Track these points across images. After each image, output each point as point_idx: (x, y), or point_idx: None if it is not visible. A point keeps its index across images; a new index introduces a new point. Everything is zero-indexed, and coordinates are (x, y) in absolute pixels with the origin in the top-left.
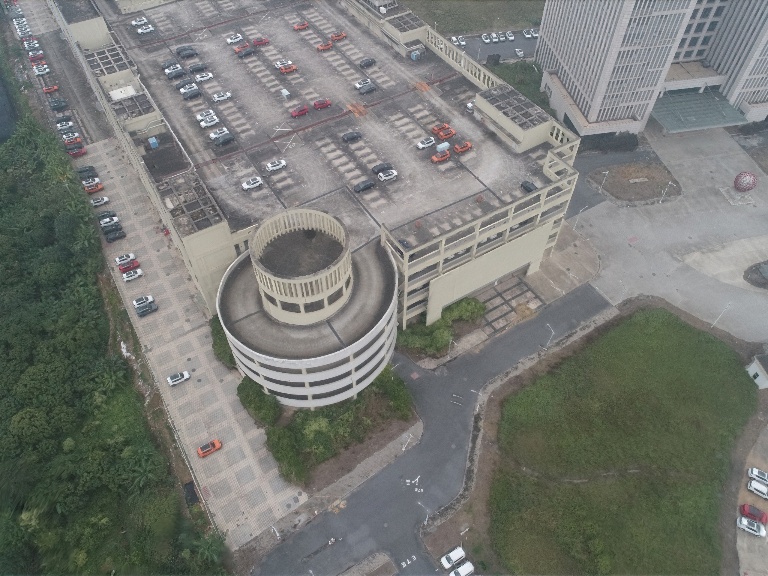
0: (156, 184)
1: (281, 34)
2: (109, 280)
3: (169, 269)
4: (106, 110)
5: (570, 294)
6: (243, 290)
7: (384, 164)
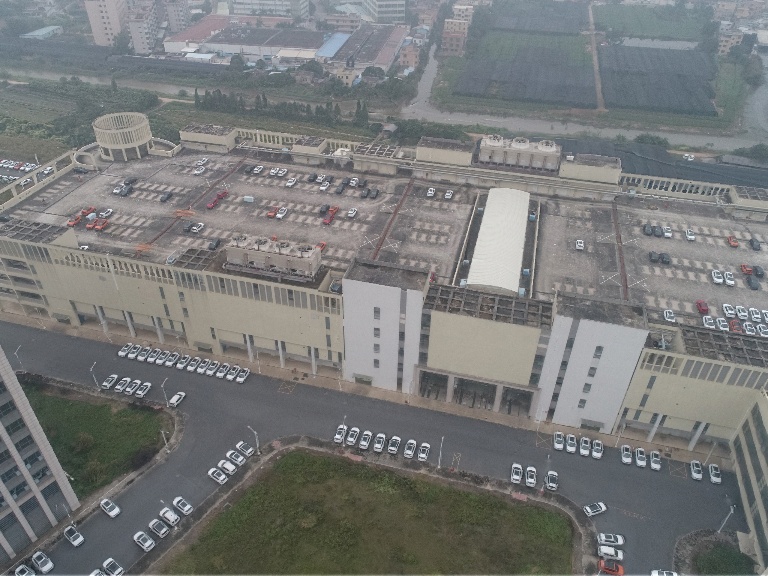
0: None
1: (329, 236)
2: None
3: None
4: None
5: None
6: None
7: (126, 190)
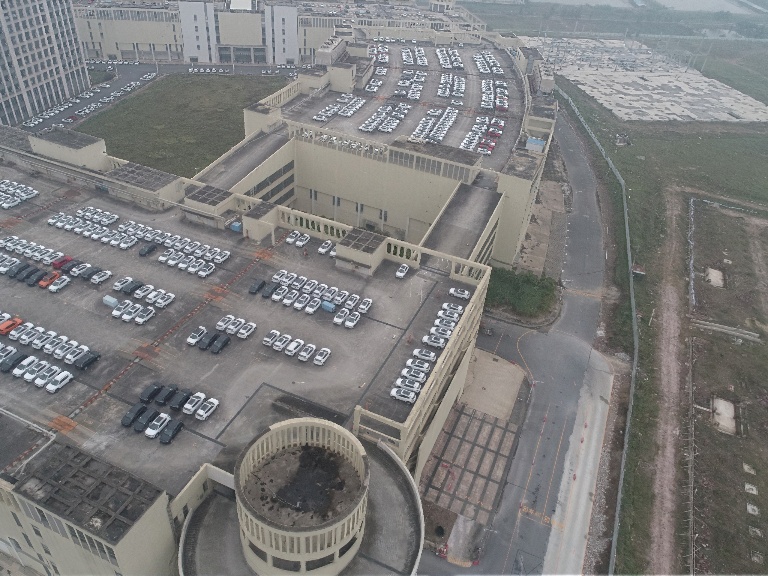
0: None
1: None
2: None
3: None
4: None
5: None
6: None
7: None
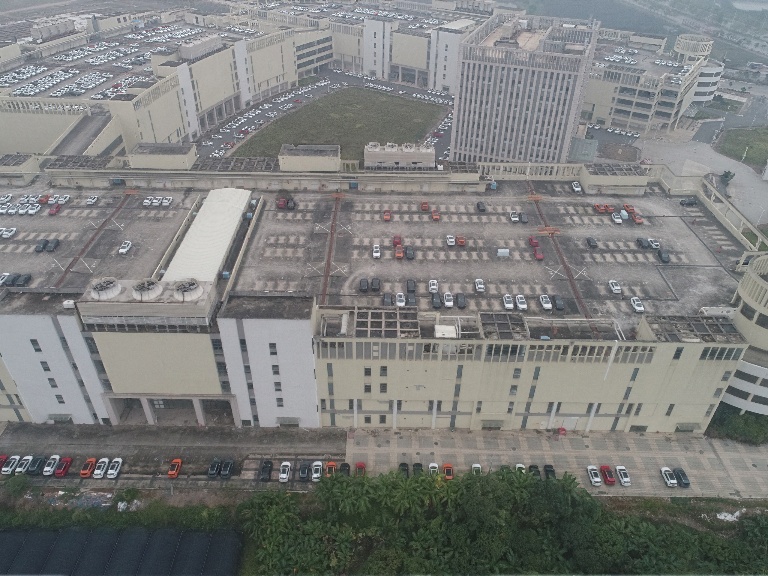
0: (658, 340)
1: (387, 229)
2: (617, 502)
3: (620, 446)
4: (359, 396)
5: None
6: (758, 360)
7: (642, 239)
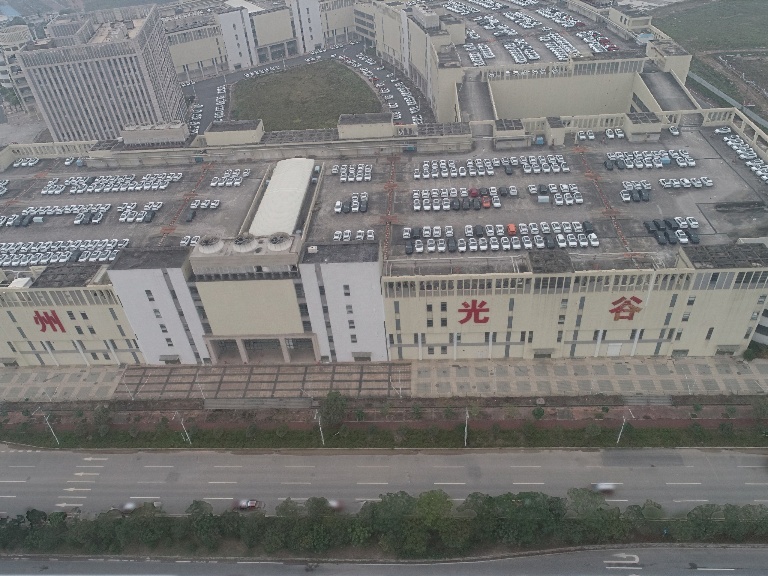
0: None
1: None
2: None
3: None
4: None
5: (6, 119)
6: None
7: None
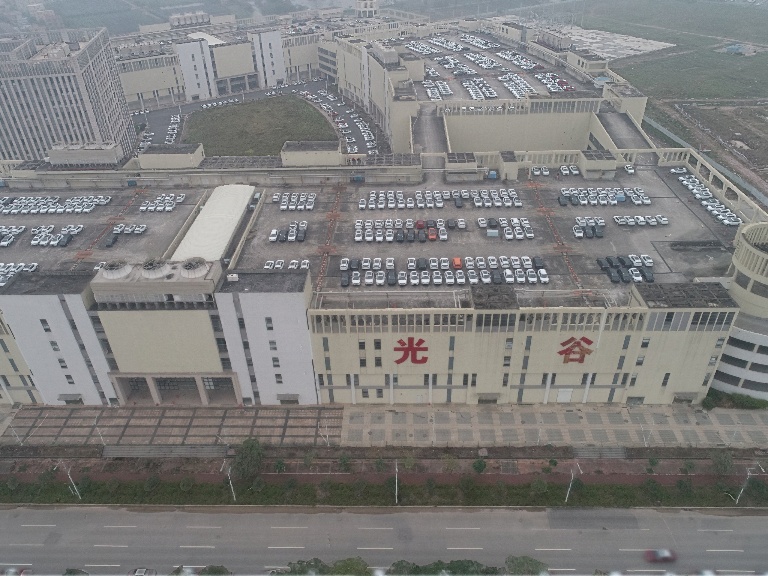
0: None
1: None
2: None
3: None
4: None
5: None
6: None
7: None
